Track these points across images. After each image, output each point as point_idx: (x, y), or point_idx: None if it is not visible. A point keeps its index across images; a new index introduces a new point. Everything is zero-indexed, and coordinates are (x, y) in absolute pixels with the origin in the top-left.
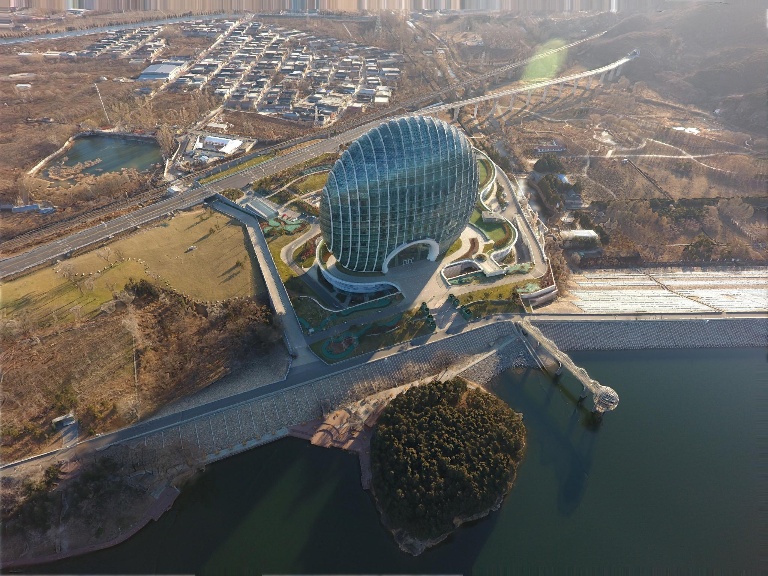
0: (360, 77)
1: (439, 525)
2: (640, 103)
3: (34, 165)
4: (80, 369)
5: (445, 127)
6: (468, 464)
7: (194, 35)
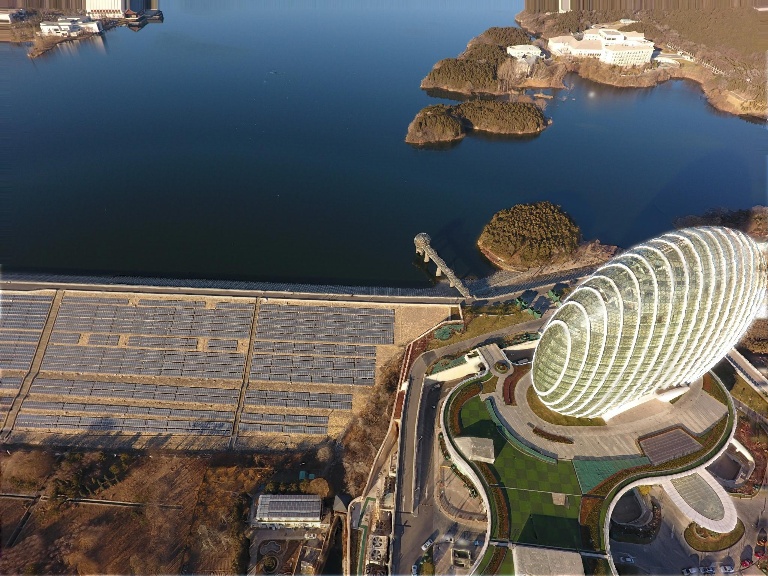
0: None
1: None
2: None
3: None
4: None
5: None
6: None
7: None
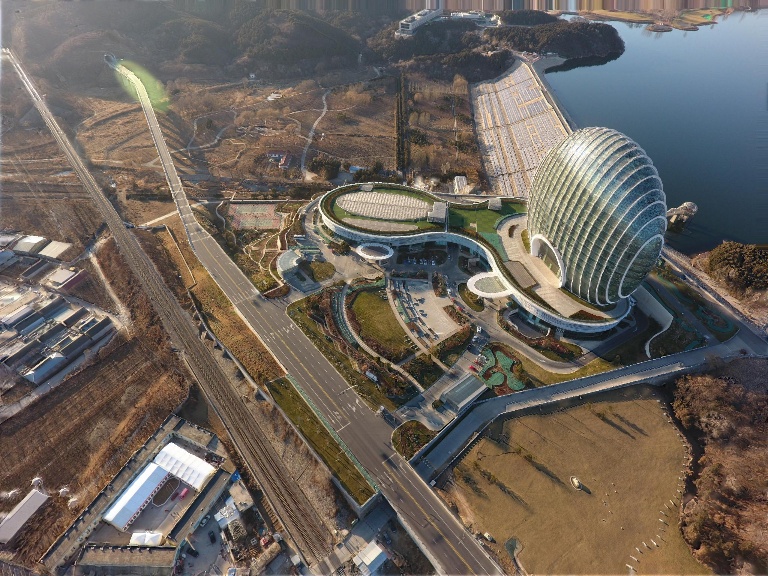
0: None
1: None
2: None
3: None
4: None
5: None
6: None
7: None
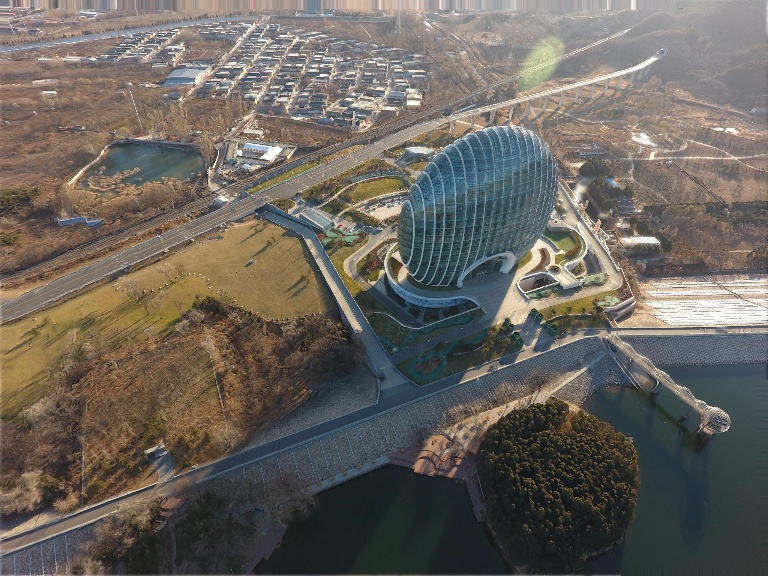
0: (387, 79)
1: (572, 562)
2: (674, 103)
3: (73, 175)
4: (165, 395)
5: (532, 137)
6: (592, 495)
7: (212, 38)
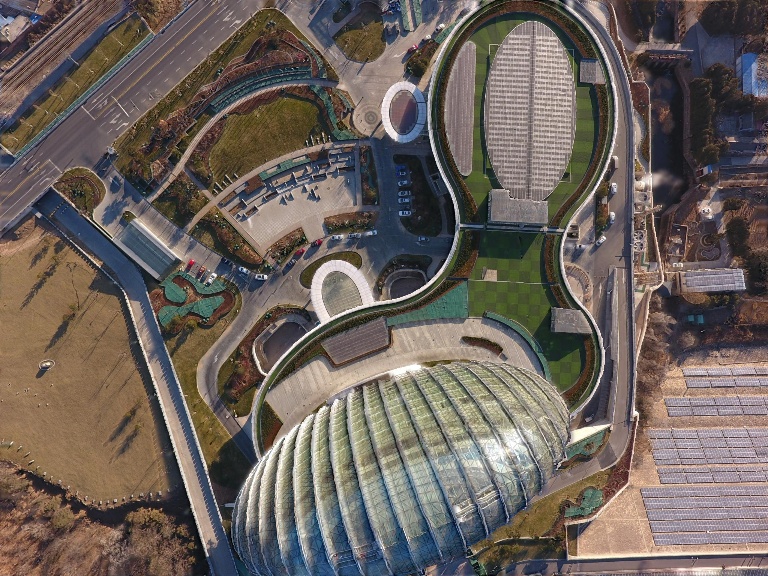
0: None
1: None
2: None
3: None
4: None
5: (510, 505)
6: None
7: None
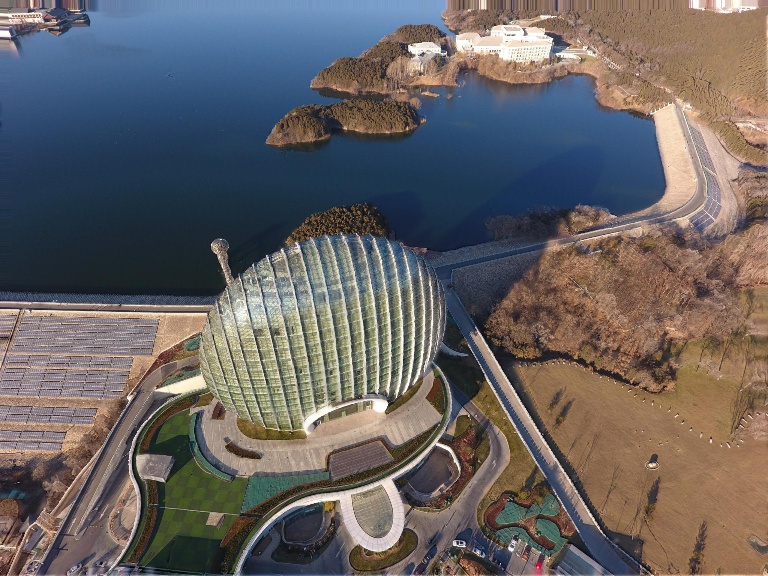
0: None
1: None
2: None
3: None
4: None
5: None
6: None
7: None
